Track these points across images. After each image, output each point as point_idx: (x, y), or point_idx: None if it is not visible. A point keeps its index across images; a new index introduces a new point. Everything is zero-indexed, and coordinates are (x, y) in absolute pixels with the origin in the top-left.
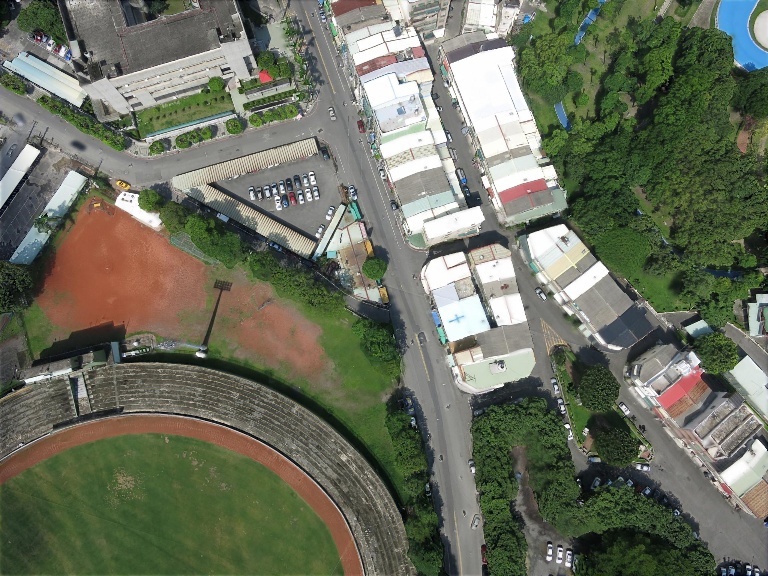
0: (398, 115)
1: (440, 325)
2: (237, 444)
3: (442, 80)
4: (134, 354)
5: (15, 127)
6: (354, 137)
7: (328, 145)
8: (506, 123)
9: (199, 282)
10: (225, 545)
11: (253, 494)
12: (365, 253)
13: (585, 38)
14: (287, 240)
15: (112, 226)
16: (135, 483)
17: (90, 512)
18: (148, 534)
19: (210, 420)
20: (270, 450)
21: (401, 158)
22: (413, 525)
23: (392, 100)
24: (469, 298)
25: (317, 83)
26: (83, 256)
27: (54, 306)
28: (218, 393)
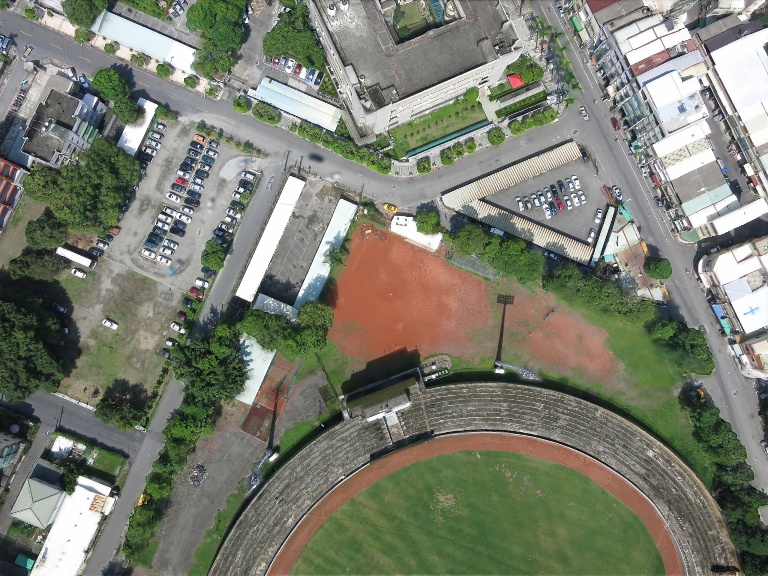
0: (679, 113)
1: (724, 317)
2: (545, 452)
3: None
4: (435, 377)
5: (269, 159)
6: (609, 135)
7: (585, 146)
8: None
9: (482, 299)
10: (549, 547)
11: (567, 497)
12: (642, 253)
13: None
14: (565, 248)
15: (387, 252)
16: (456, 500)
17: (418, 532)
18: (476, 546)
19: (518, 432)
20: (576, 454)
21: (677, 156)
22: (745, 511)
23: (678, 99)
24: (760, 289)
25: (564, 82)
26: (364, 285)
27: (345, 338)
28: (523, 406)
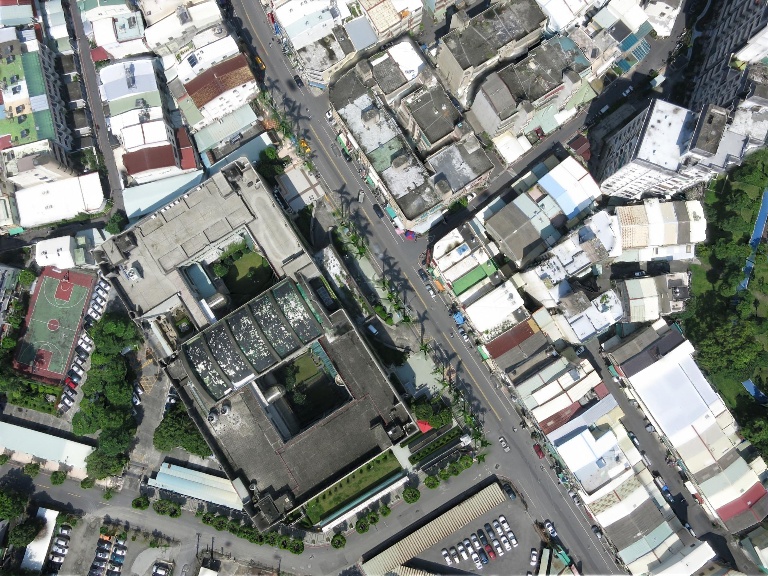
0: (599, 469)
1: None
2: None
3: (610, 375)
4: None
5: (180, 546)
6: (534, 465)
7: (510, 481)
8: (705, 430)
9: None
10: None
11: None
12: None
13: (750, 285)
14: None
15: None
16: None
17: None
18: None
19: None
20: None
21: (606, 501)
22: None
23: (593, 461)
24: None
25: (478, 413)
26: None
27: None
28: None
